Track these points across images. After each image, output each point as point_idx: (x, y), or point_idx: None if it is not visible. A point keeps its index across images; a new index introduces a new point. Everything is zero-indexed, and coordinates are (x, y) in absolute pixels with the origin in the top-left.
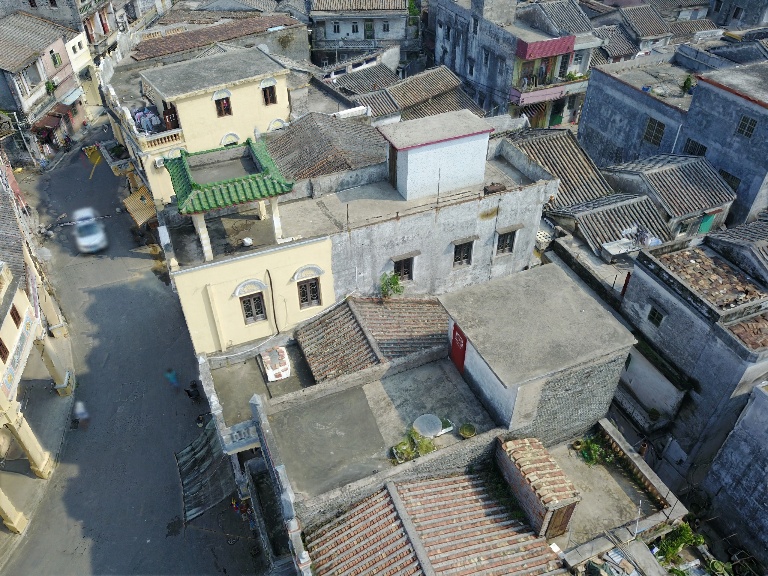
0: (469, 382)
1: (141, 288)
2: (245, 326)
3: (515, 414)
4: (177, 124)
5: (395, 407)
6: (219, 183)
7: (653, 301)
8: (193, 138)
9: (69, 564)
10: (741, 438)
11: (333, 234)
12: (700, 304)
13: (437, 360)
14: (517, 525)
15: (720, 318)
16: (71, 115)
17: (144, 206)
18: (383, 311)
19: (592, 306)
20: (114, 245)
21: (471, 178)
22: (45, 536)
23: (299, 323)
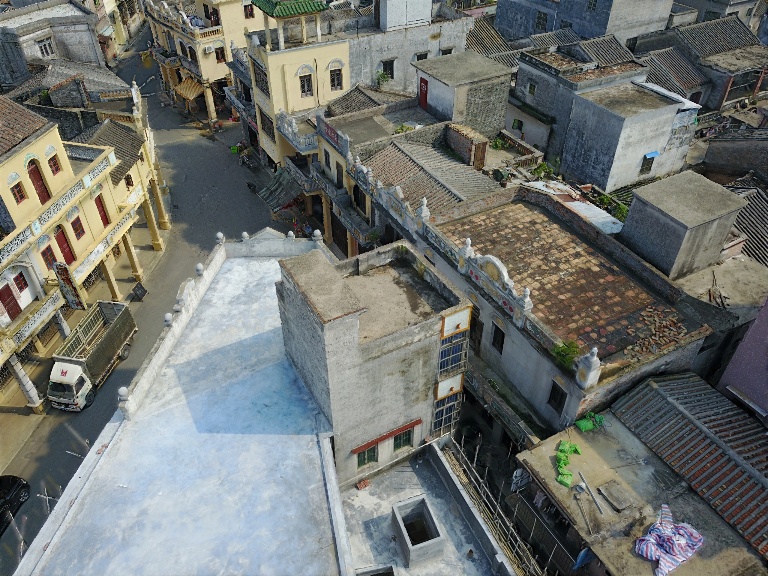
0: (430, 111)
1: (196, 144)
2: (301, 98)
3: (455, 109)
4: (218, 23)
5: (392, 123)
6: (290, 3)
7: (530, 80)
8: (229, 33)
9: (197, 260)
10: (572, 129)
11: (350, 39)
12: (551, 69)
13: (412, 107)
14: (459, 162)
15: (560, 72)
16: (106, 47)
17: (192, 89)
18: (378, 94)
19: (491, 62)
20: (167, 123)
21: (423, 21)
22: (177, 251)
23: (330, 101)
